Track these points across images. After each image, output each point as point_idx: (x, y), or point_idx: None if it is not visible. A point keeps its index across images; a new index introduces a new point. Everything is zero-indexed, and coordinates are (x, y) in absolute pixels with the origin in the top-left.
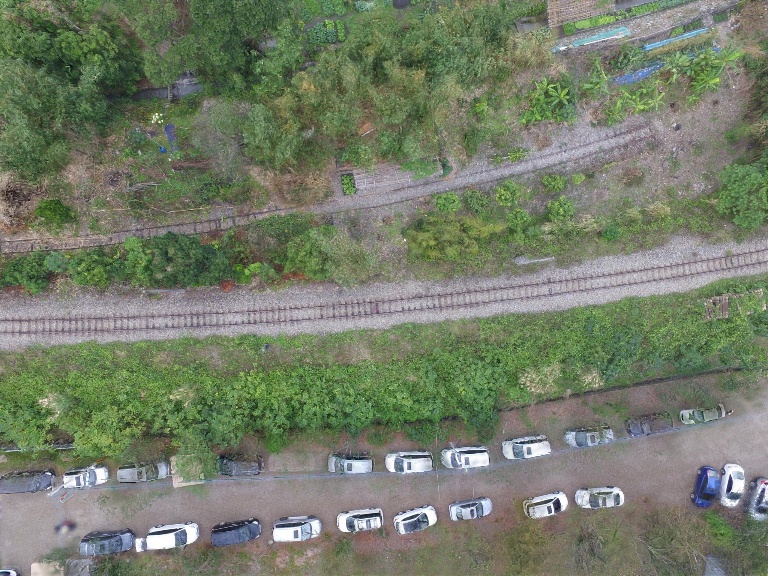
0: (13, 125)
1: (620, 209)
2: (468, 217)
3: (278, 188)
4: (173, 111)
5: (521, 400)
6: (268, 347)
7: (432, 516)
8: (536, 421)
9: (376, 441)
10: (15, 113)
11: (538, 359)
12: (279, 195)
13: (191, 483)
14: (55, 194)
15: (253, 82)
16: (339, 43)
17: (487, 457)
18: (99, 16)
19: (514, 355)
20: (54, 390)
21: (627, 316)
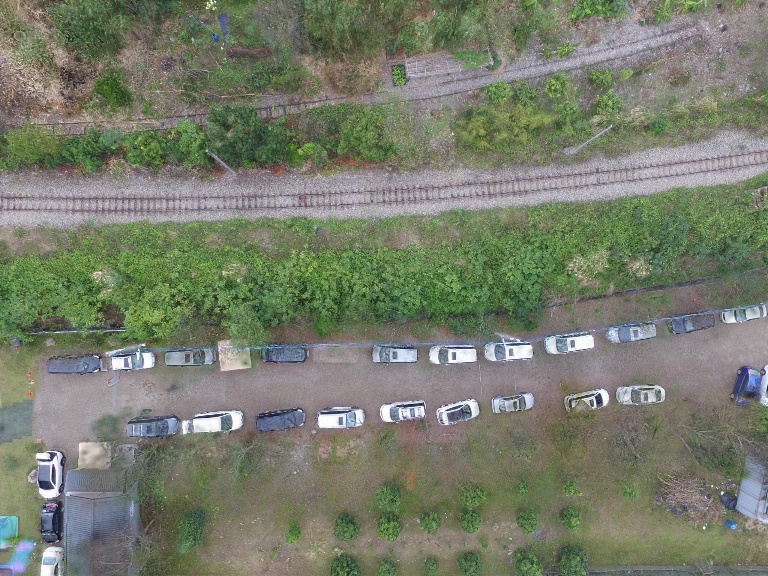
0: None
1: (666, 108)
2: (517, 108)
3: (329, 78)
4: None
5: (569, 286)
6: (319, 229)
7: (475, 408)
8: (578, 318)
9: (420, 333)
10: None
11: (585, 247)
12: (330, 85)
13: (238, 367)
14: None
15: None
16: None
17: (531, 349)
18: None
19: (562, 242)
20: (107, 267)
21: (674, 206)
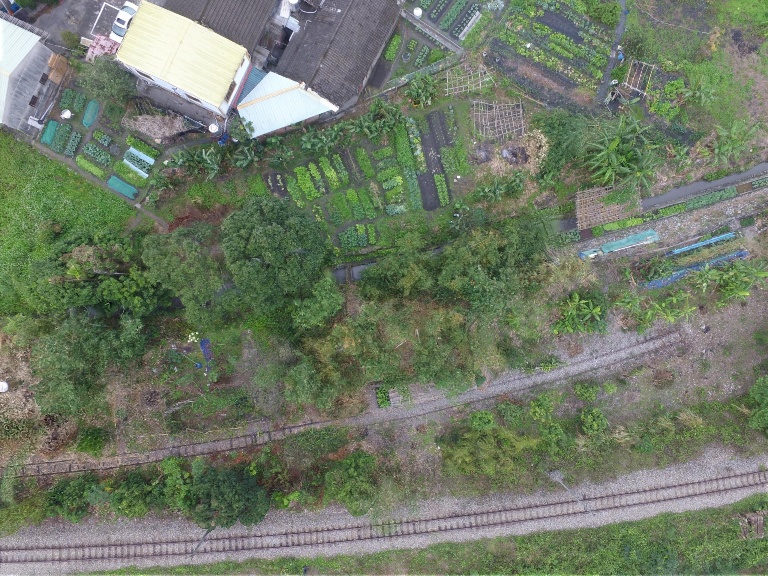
0: (59, 391)
1: (651, 412)
2: (502, 432)
3: None
4: (208, 326)
5: None
6: (306, 571)
7: None
8: None
9: None
10: (61, 379)
11: None
12: (314, 408)
13: None
14: (92, 414)
15: (288, 303)
16: (370, 246)
17: None
18: (133, 226)
19: (551, 575)
20: None
21: (662, 533)
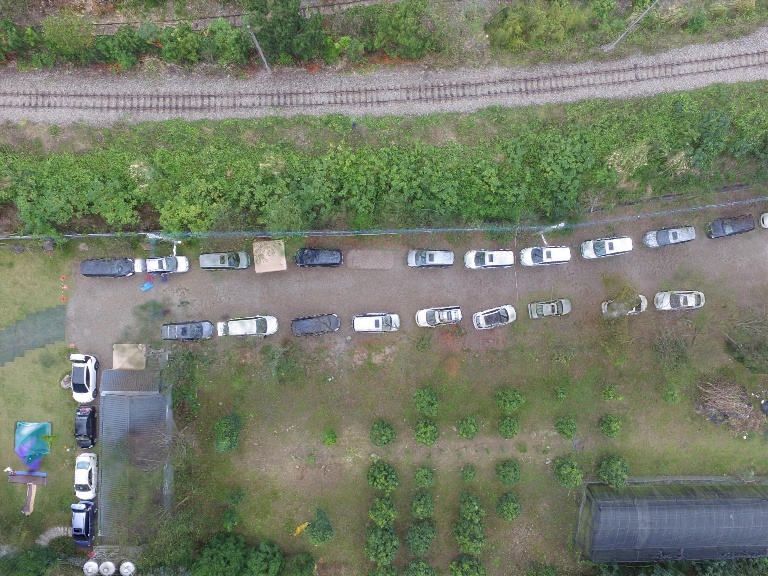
0: None
1: None
2: (554, 6)
3: None
4: None
5: (609, 180)
6: (355, 126)
7: (512, 313)
8: (615, 224)
9: (456, 238)
10: None
11: (625, 143)
12: None
13: (273, 268)
14: None
15: None
16: None
17: (569, 251)
18: None
19: (601, 137)
20: None
21: (714, 102)
